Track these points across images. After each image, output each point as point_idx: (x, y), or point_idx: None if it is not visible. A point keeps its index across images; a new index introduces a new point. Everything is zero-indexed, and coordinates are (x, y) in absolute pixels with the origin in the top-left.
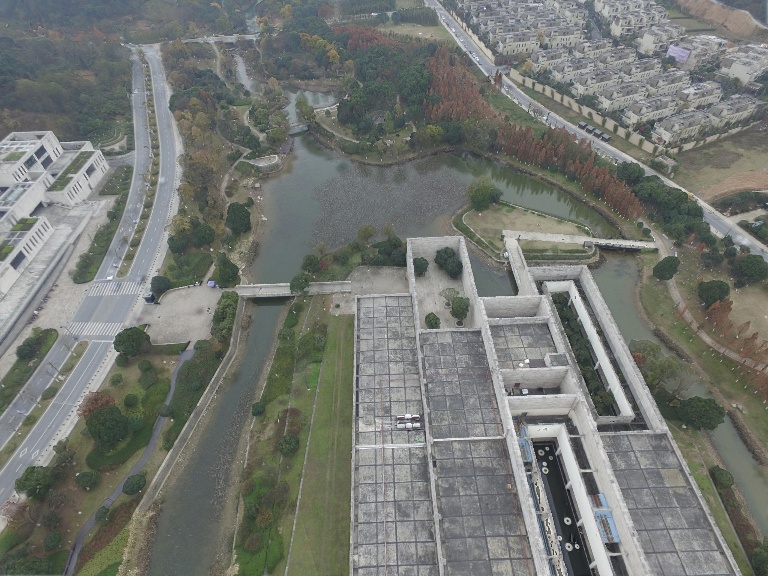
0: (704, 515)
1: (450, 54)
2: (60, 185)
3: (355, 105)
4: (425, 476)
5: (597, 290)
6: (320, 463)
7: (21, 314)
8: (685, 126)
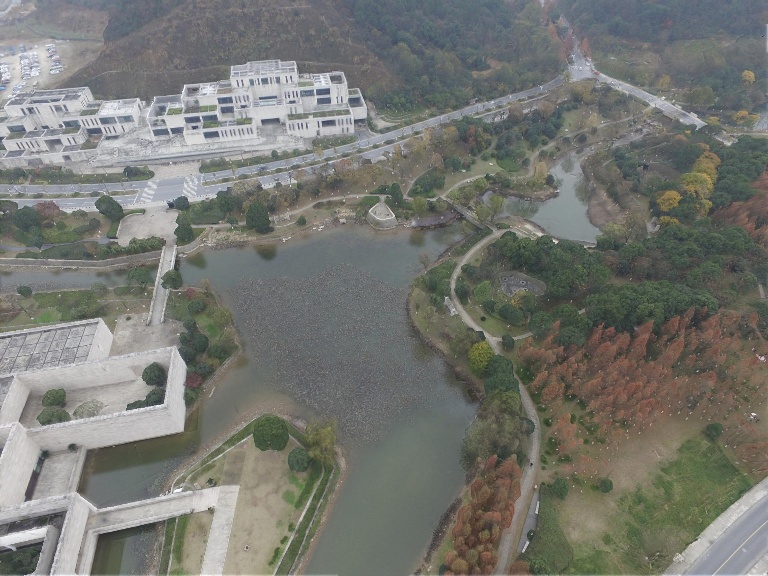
0: None
1: None
2: (295, 117)
3: (498, 246)
4: None
5: None
6: None
7: (168, 158)
8: None
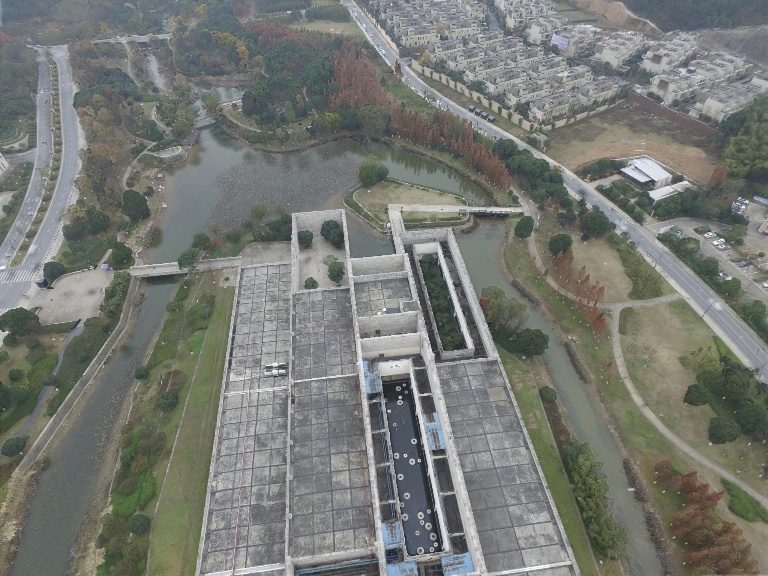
0: (518, 421)
1: (356, 48)
2: None
3: (257, 96)
4: (285, 413)
5: (457, 248)
6: (197, 414)
7: None
8: (555, 105)
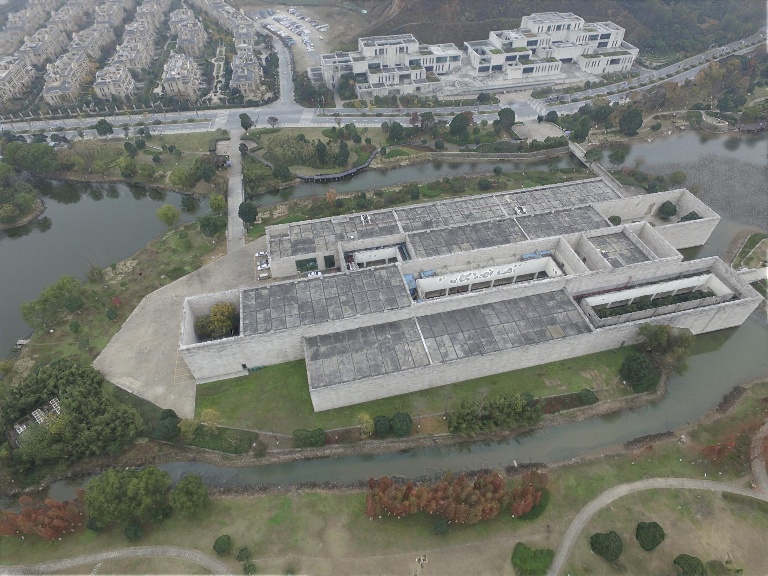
0: None
1: None
2: (590, 56)
3: None
4: None
5: (732, 302)
6: None
7: (500, 88)
8: None
